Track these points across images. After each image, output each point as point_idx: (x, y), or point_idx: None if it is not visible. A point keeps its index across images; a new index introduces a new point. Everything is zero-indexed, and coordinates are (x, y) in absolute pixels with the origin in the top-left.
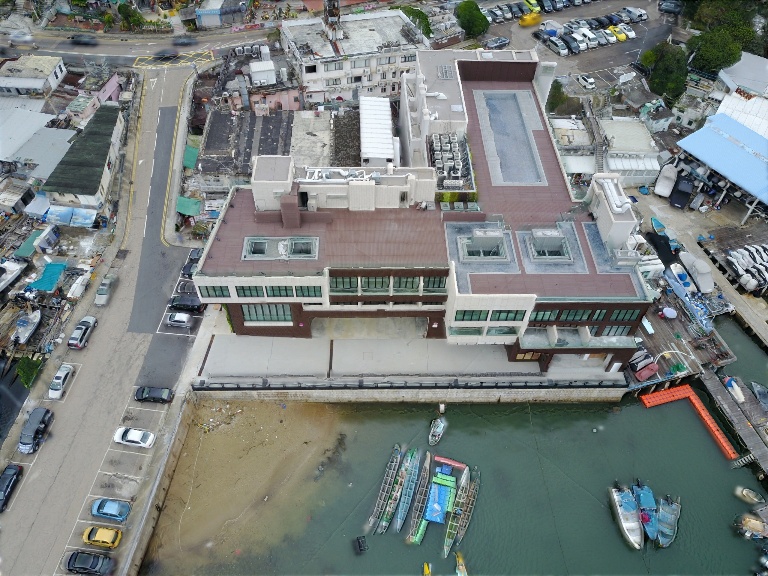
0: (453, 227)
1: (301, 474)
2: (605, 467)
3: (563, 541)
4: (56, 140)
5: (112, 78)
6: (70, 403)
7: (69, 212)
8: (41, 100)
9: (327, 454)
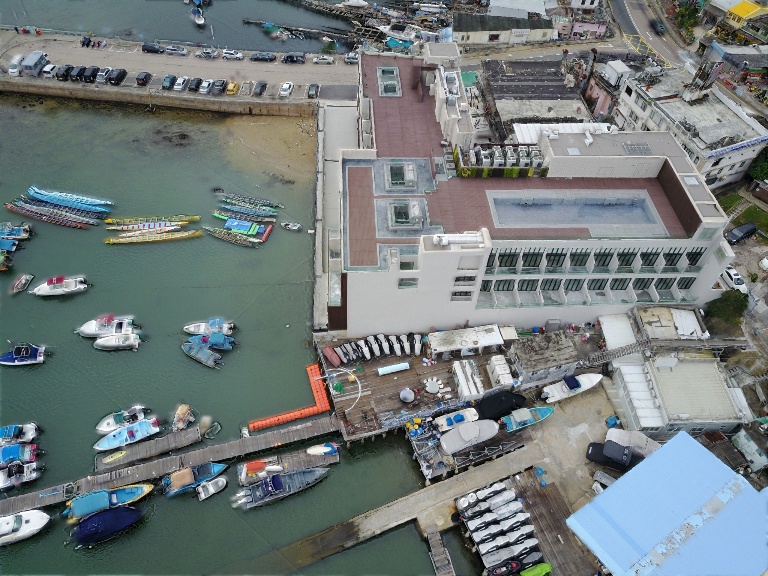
0: (426, 163)
1: (268, 166)
2: (255, 327)
3: (202, 290)
4: (514, 16)
5: (597, 25)
6: (311, 67)
7: (449, 35)
8: (558, 5)
9: (280, 176)
